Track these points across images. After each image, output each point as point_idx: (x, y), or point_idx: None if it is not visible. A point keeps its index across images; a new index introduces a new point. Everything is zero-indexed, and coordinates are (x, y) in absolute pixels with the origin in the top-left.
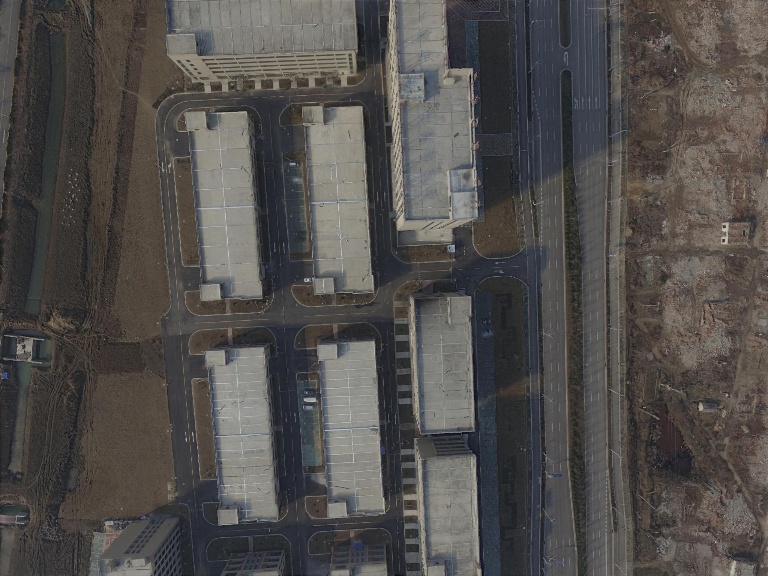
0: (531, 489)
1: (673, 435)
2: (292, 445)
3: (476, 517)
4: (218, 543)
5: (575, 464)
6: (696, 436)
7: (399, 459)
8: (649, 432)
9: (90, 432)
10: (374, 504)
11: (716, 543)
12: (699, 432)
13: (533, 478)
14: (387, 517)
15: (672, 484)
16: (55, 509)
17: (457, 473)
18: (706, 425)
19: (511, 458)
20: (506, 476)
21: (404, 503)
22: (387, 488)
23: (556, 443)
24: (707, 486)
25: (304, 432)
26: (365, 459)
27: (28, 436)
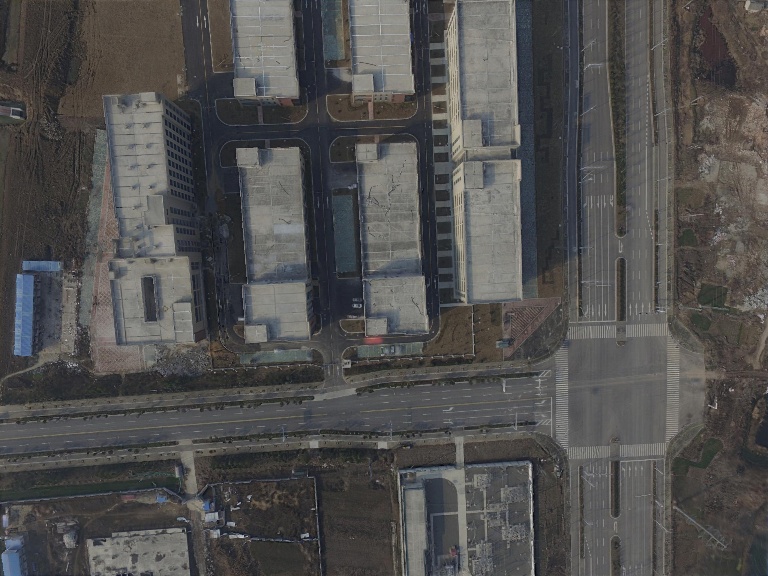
0: (568, 93)
1: (717, 42)
2: (313, 35)
3: (515, 72)
4: (232, 146)
5: (615, 62)
6: (742, 41)
7: (428, 55)
8: (692, 36)
9: (92, 14)
10: (402, 85)
11: (761, 163)
12: (745, 37)
13: (570, 81)
14: (414, 121)
15: (716, 95)
16: (54, 103)
17: (495, 21)
18: (752, 29)
19: (547, 56)
20: (542, 77)
21: (433, 105)
22: (415, 87)
23: None
24: (752, 98)
25: (326, 20)
26: (393, 32)
27: (24, 18)
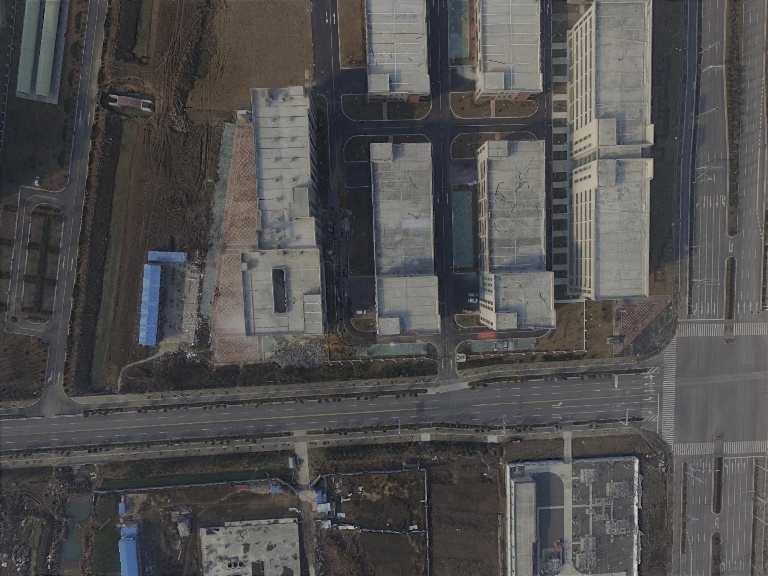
0: (685, 95)
1: None
2: (439, 33)
3: (648, 72)
4: (356, 141)
5: (733, 65)
6: None
7: (550, 54)
8: None
9: (224, 9)
10: (530, 83)
11: None
12: None
13: (687, 82)
14: (535, 119)
15: None
16: (183, 96)
17: (630, 21)
18: None
19: (666, 58)
20: (660, 78)
21: (553, 104)
22: None
23: (713, 44)
24: None
25: (452, 19)
26: (523, 31)
27: (157, 12)
